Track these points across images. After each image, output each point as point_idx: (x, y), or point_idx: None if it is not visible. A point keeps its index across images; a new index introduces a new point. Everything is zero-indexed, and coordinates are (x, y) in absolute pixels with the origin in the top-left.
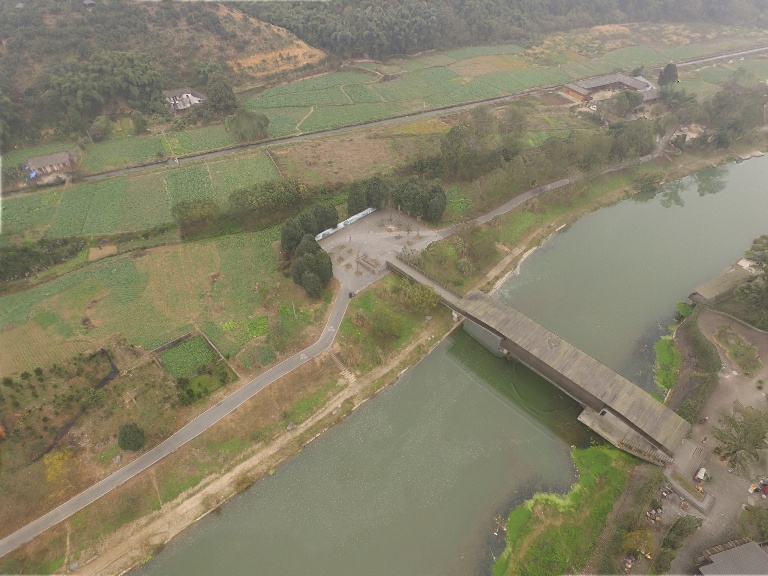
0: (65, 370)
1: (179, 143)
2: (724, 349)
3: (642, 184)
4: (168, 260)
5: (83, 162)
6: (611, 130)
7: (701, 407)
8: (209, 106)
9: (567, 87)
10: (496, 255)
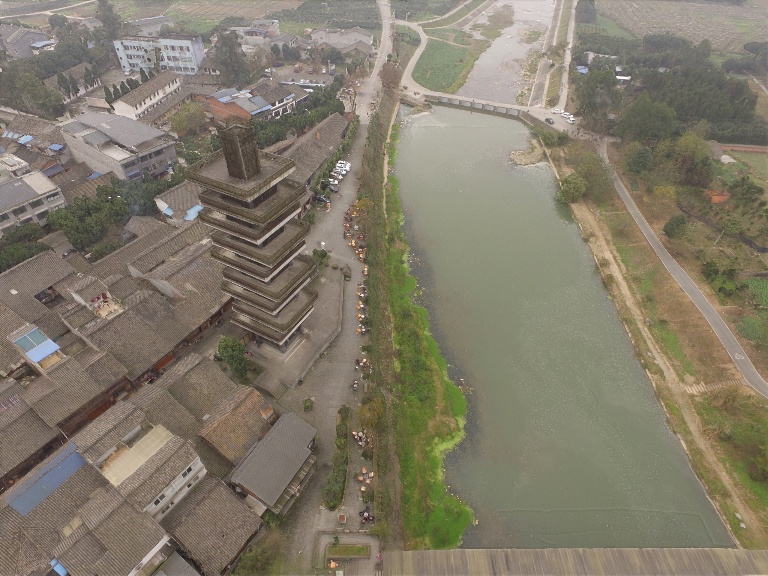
0: None
1: None
2: None
3: None
4: None
5: None
6: None
7: None
8: None
9: None
10: None
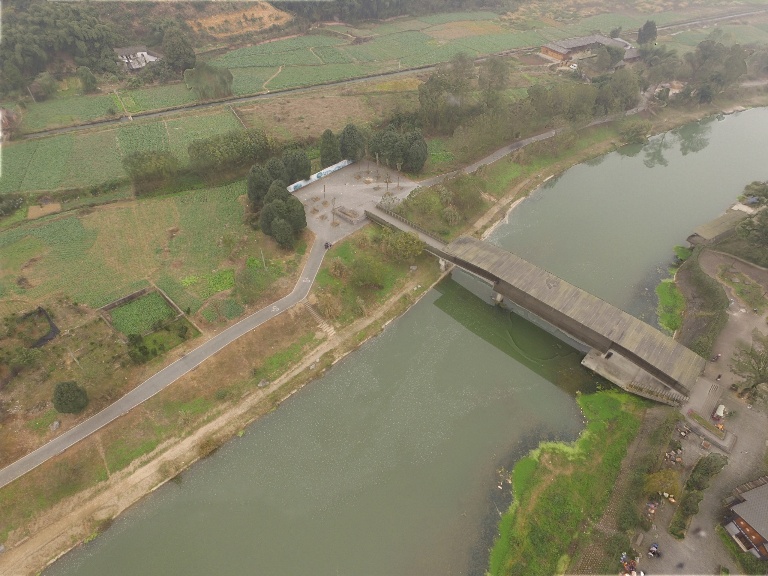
0: None
1: (133, 101)
2: (729, 288)
3: (629, 136)
4: (120, 216)
5: (23, 120)
6: (594, 83)
7: (712, 345)
8: (166, 64)
9: (546, 47)
10: (483, 205)
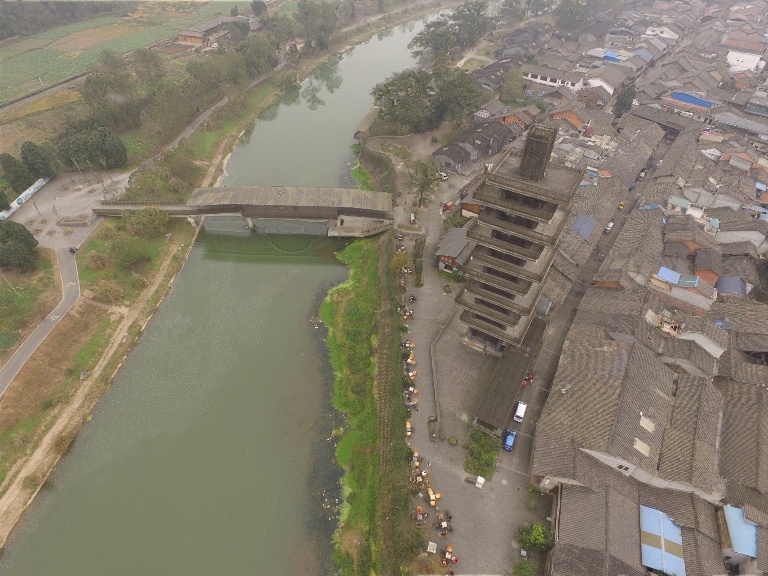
0: None
1: None
2: (389, 154)
3: (284, 85)
4: None
5: None
6: (238, 53)
7: (394, 188)
8: None
9: (182, 35)
10: (200, 170)
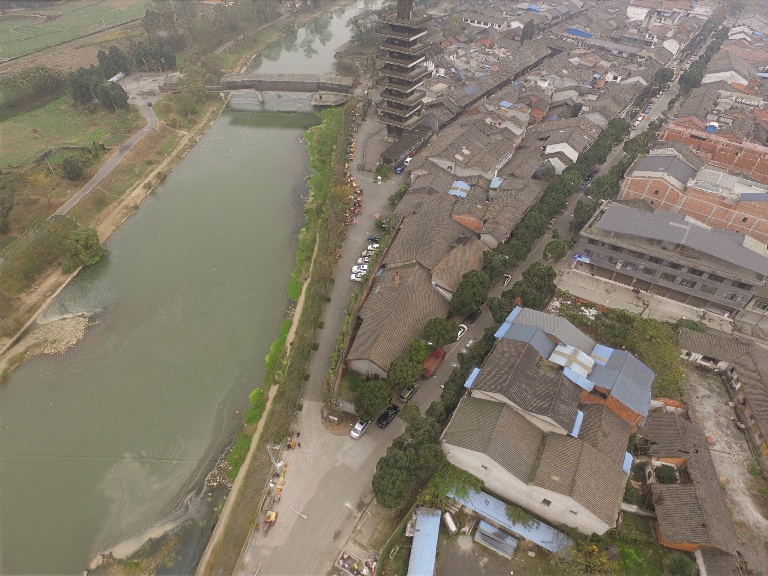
0: None
1: None
2: None
3: (285, 29)
4: None
5: None
6: None
7: (357, 81)
8: None
9: None
10: None
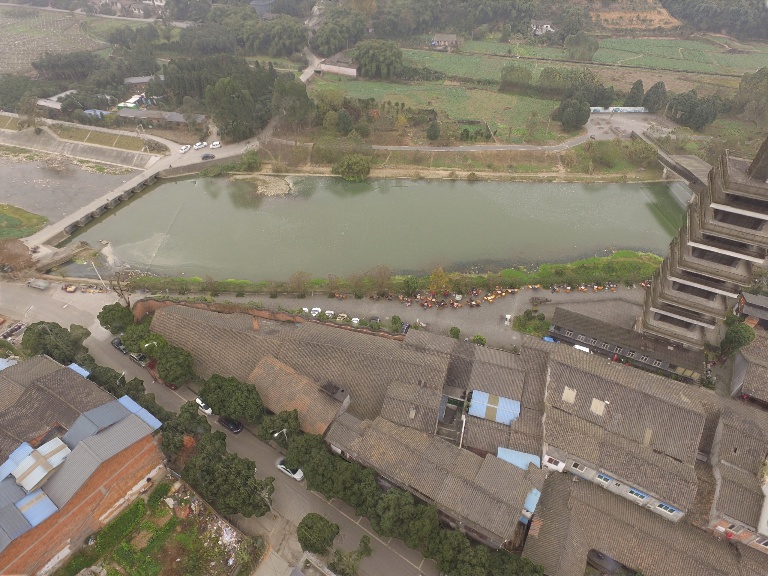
0: (413, 111)
1: (525, 51)
2: None
3: None
4: (485, 95)
5: (462, 46)
6: None
7: None
8: (559, 34)
9: None
10: None
